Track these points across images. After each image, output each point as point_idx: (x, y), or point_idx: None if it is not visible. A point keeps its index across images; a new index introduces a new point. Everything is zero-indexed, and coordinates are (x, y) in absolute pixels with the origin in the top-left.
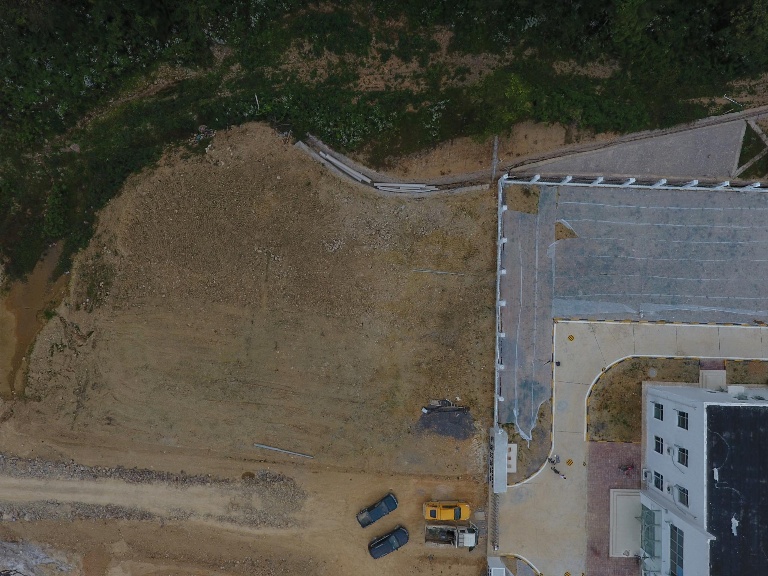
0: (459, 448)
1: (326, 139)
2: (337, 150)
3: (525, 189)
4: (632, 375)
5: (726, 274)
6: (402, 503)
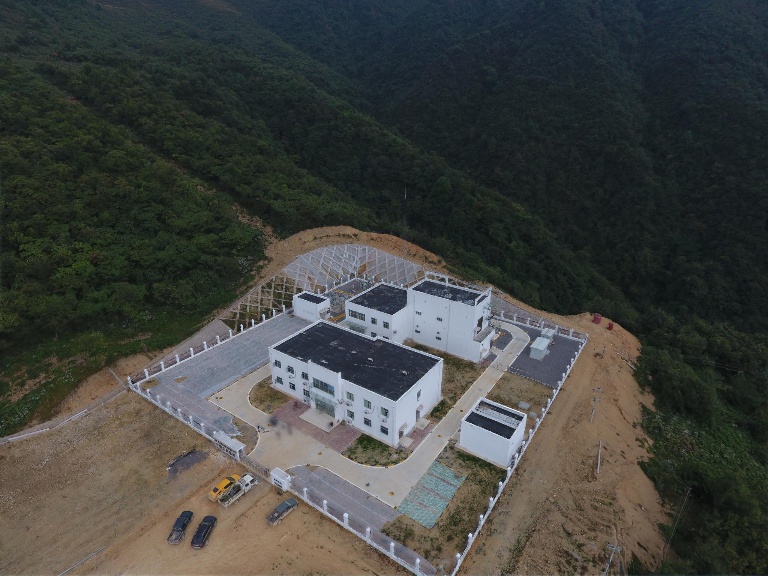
0: (206, 465)
1: (3, 433)
2: (15, 433)
3: (147, 382)
4: (262, 387)
5: (264, 348)
6: (196, 513)
